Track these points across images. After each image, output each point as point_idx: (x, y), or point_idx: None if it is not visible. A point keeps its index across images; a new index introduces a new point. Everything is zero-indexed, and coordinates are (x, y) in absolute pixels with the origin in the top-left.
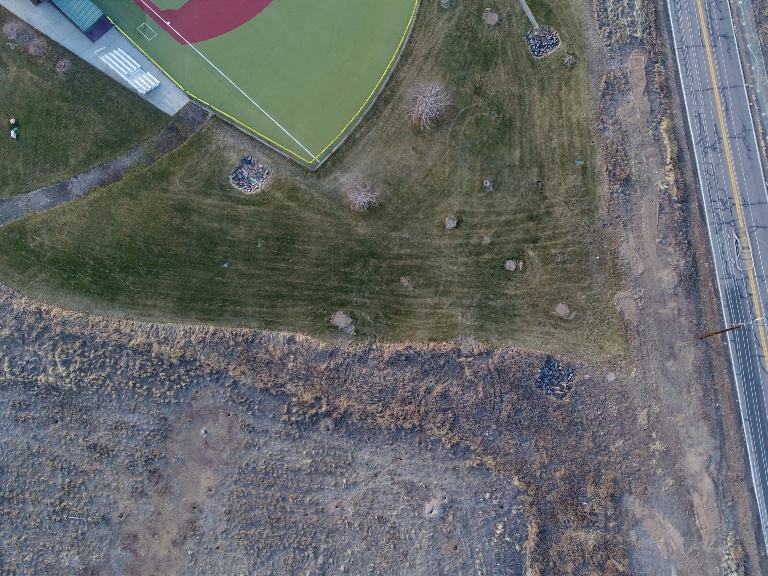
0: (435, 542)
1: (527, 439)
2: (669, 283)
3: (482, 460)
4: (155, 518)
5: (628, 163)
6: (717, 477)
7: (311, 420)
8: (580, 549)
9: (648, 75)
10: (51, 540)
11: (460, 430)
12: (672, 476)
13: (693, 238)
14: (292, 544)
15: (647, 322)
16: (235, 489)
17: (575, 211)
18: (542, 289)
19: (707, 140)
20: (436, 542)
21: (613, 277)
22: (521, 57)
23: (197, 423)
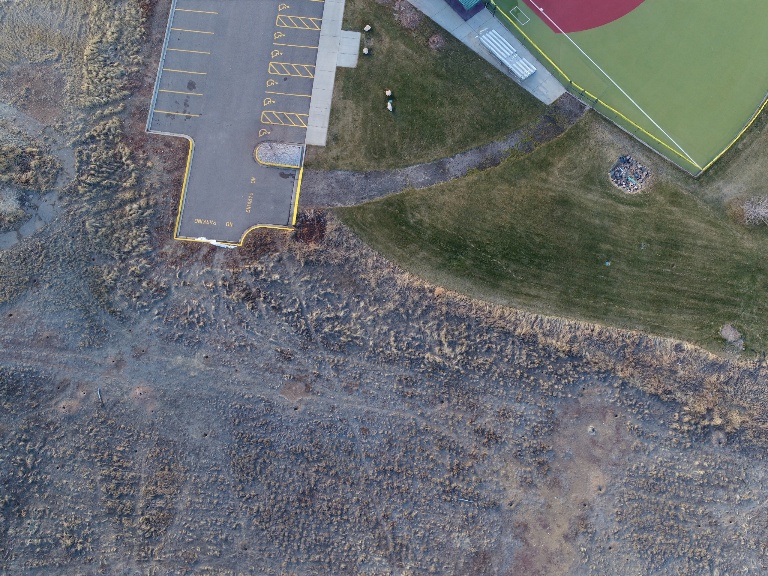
0: None
1: None
2: None
3: None
4: (545, 510)
5: None
6: None
7: (703, 431)
8: None
9: None
10: (441, 519)
11: None
12: None
13: None
14: (687, 554)
15: None
16: (626, 491)
17: None
18: None
19: None
20: None
21: None
22: None
23: (584, 420)
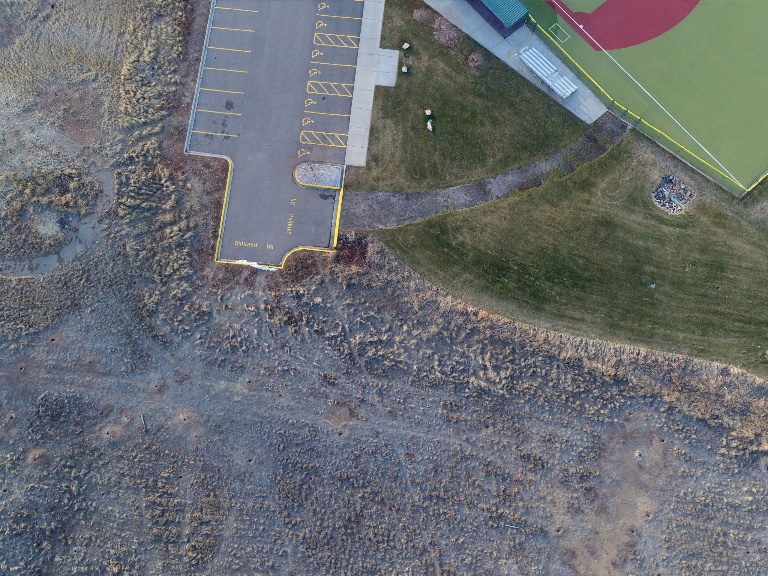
0: None
1: None
2: None
3: None
4: (593, 537)
5: None
6: None
7: (751, 457)
8: None
9: None
10: (488, 546)
11: None
12: None
13: None
14: None
15: None
16: (674, 517)
17: None
18: None
19: None
20: None
21: None
22: None
23: (630, 445)
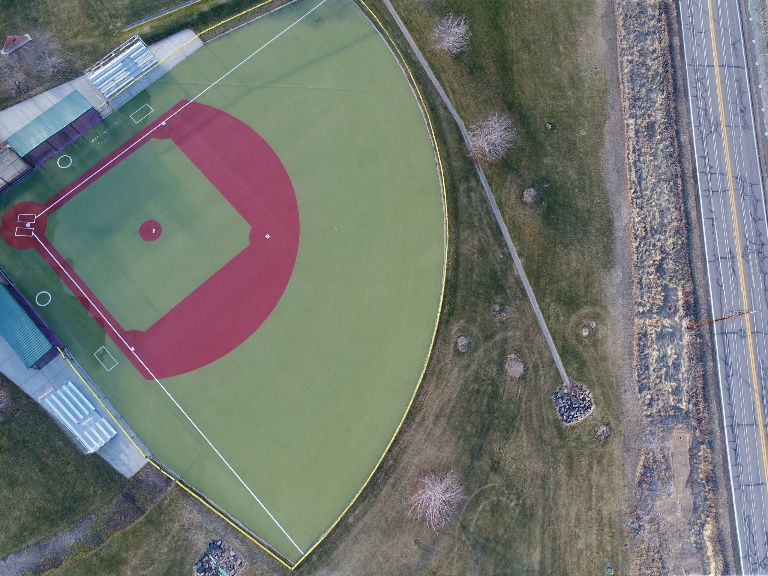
0: None
1: None
2: None
3: None
4: None
5: None
6: None
7: None
8: None
9: (692, 460)
10: None
11: None
12: None
13: None
14: None
15: None
16: None
17: None
18: None
19: (756, 553)
20: None
21: None
22: (547, 423)
23: None
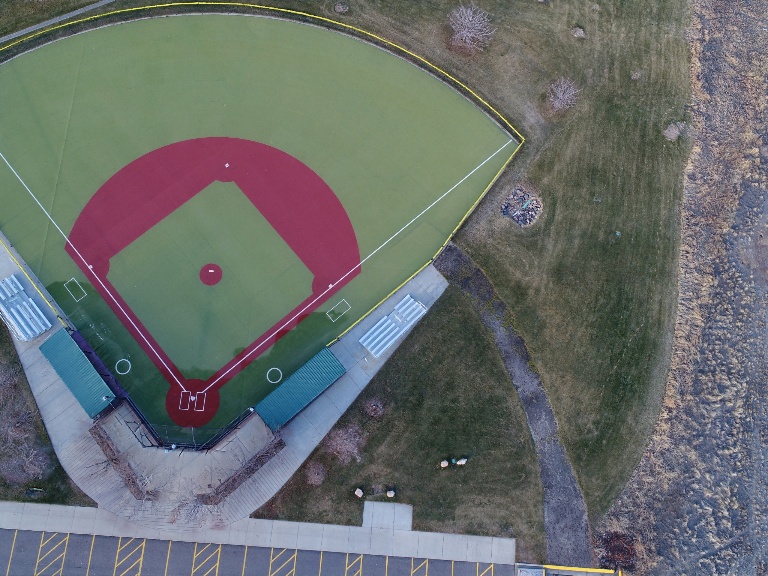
0: None
1: None
2: None
3: None
4: None
5: None
6: None
7: (764, 163)
8: None
9: None
10: None
11: (764, 48)
12: None
13: None
14: None
15: None
16: None
17: None
18: None
19: None
20: None
21: None
22: None
23: None
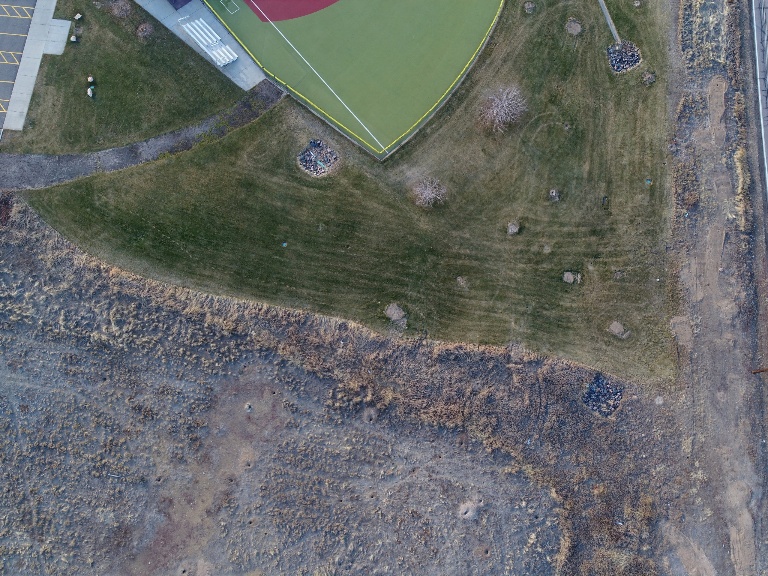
0: (466, 543)
1: (568, 452)
2: (728, 314)
3: (521, 468)
4: (192, 485)
5: (698, 188)
6: (757, 514)
7: (355, 408)
8: (611, 568)
9: (727, 102)
10: (89, 494)
11: (502, 435)
12: (711, 507)
13: (756, 271)
14: (324, 528)
15: (701, 350)
16: (273, 467)
17: (639, 230)
18: (598, 305)
19: None
20: (467, 544)
21: (671, 301)
22: (600, 70)
23: (242, 397)
